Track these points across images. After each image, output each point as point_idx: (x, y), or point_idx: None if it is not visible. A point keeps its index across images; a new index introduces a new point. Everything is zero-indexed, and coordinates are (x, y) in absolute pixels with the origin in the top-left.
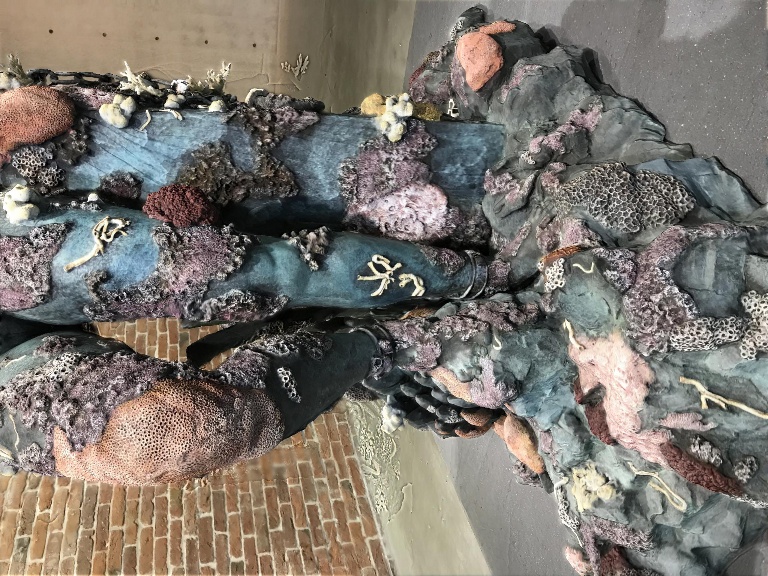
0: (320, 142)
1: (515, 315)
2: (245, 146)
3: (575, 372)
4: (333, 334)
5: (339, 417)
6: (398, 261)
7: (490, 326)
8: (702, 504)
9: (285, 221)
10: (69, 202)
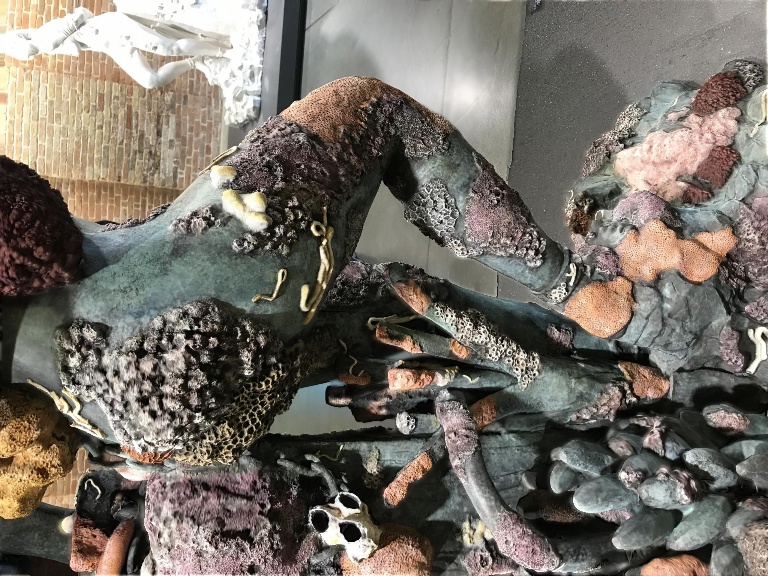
0: None
1: None
2: None
3: (681, 206)
4: None
5: None
6: None
7: None
8: (767, 85)
9: None
10: None
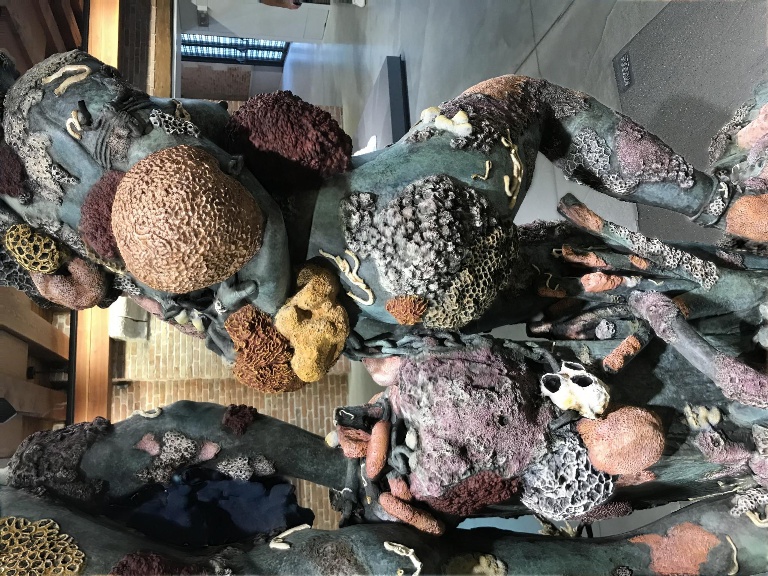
0: None
1: None
2: None
3: None
4: None
5: None
6: None
7: None
8: None
9: None
10: None
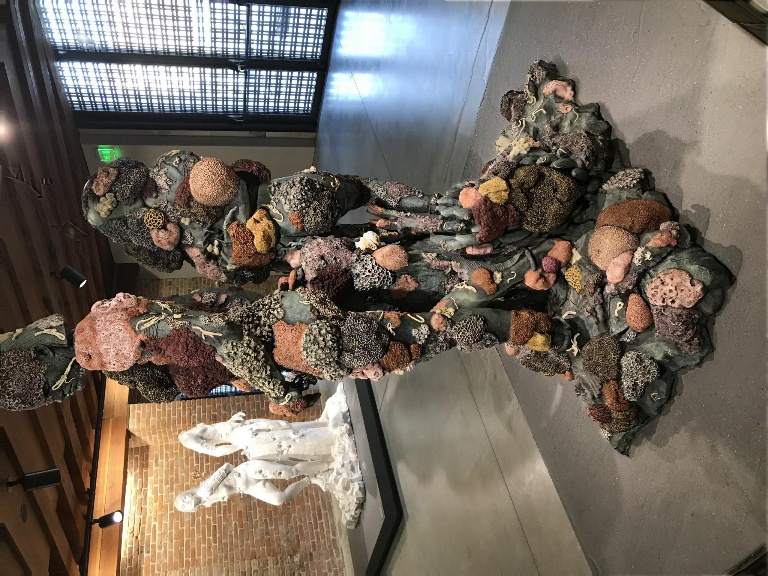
0: None
1: None
2: None
3: None
4: None
5: None
6: None
7: None
8: None
9: None
10: None
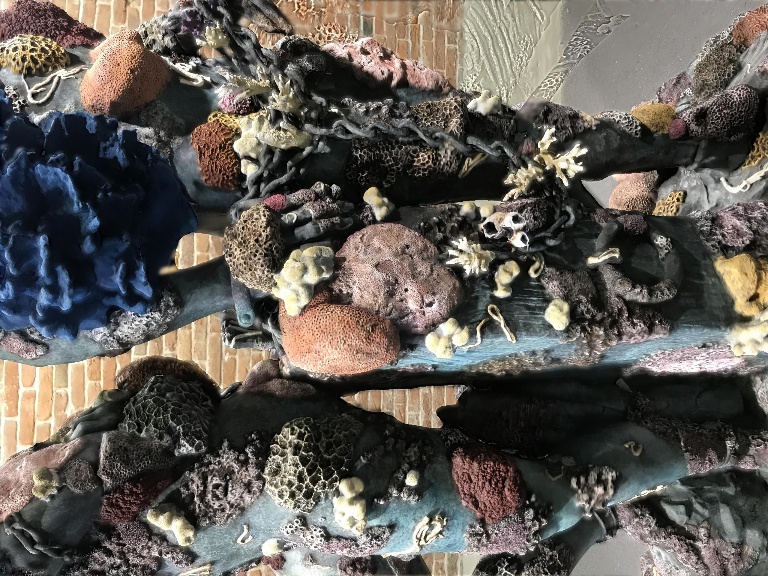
0: (652, 343)
1: (735, 564)
2: (568, 349)
3: None
4: (575, 539)
5: (450, 37)
6: (662, 484)
7: (709, 573)
8: None
9: (565, 370)
10: (389, 485)
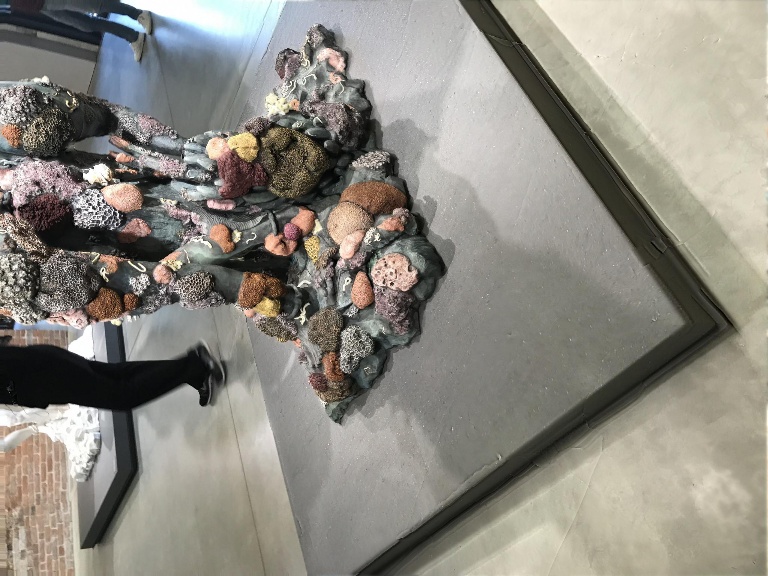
0: None
1: None
2: None
3: None
4: None
5: None
6: None
7: None
8: None
9: None
10: None
